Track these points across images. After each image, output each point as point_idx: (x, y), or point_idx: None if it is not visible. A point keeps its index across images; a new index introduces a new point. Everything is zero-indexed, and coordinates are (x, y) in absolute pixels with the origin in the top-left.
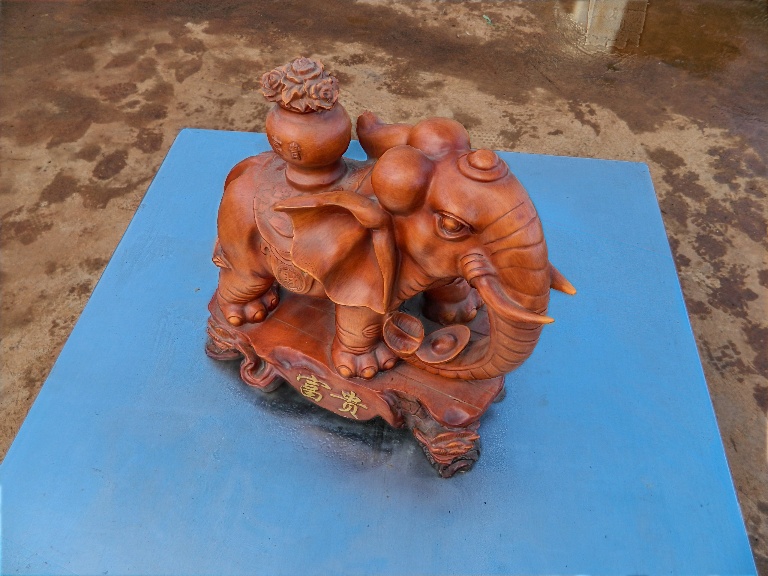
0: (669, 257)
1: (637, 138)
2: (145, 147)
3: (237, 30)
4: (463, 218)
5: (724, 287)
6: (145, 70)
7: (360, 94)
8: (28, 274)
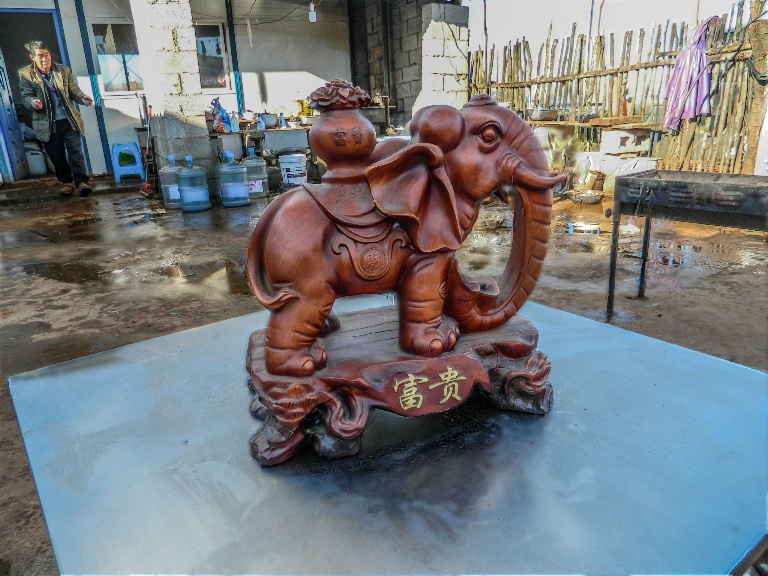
0: None
1: None
2: None
3: None
4: (498, 122)
5: None
6: None
7: None
8: None
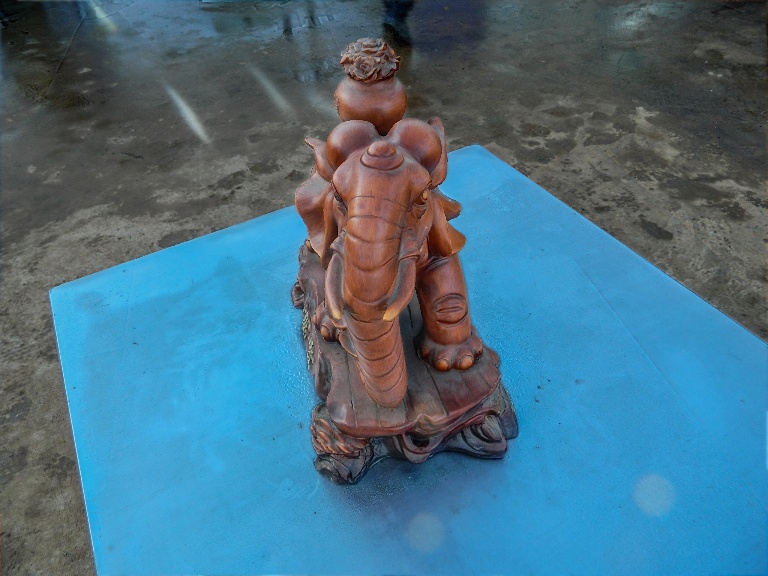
0: None
1: None
2: None
3: (677, 129)
4: (335, 186)
5: None
6: (568, 125)
7: (739, 234)
8: None
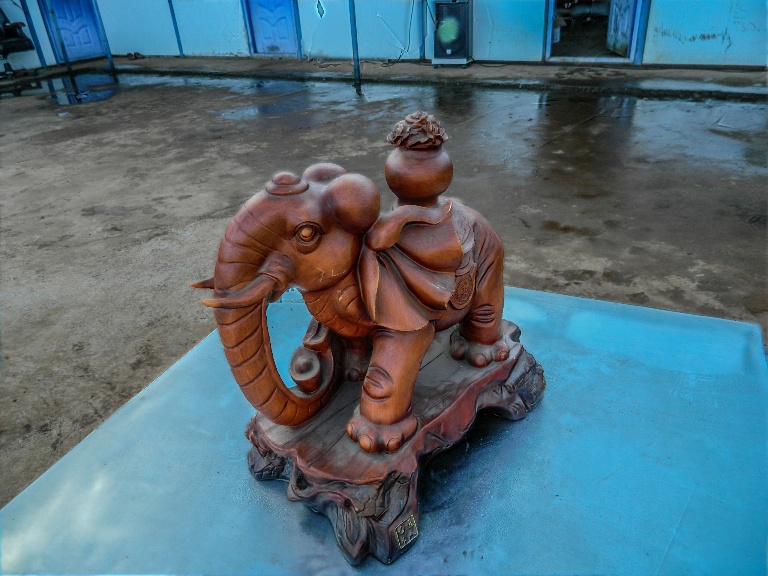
0: None
1: None
2: None
3: None
4: None
5: None
6: None
7: None
8: None
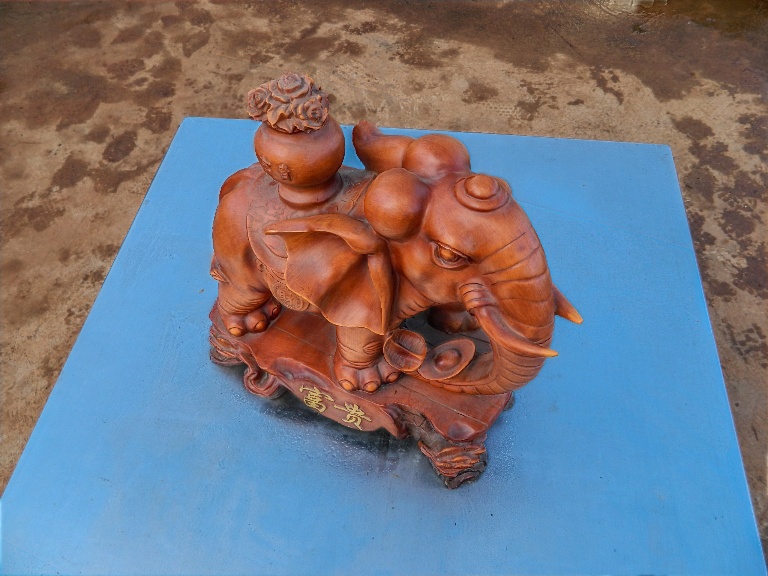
0: (690, 250)
1: (663, 106)
2: (154, 127)
3: None
4: (460, 250)
5: (751, 267)
6: (152, 45)
7: (372, 65)
8: (42, 262)
